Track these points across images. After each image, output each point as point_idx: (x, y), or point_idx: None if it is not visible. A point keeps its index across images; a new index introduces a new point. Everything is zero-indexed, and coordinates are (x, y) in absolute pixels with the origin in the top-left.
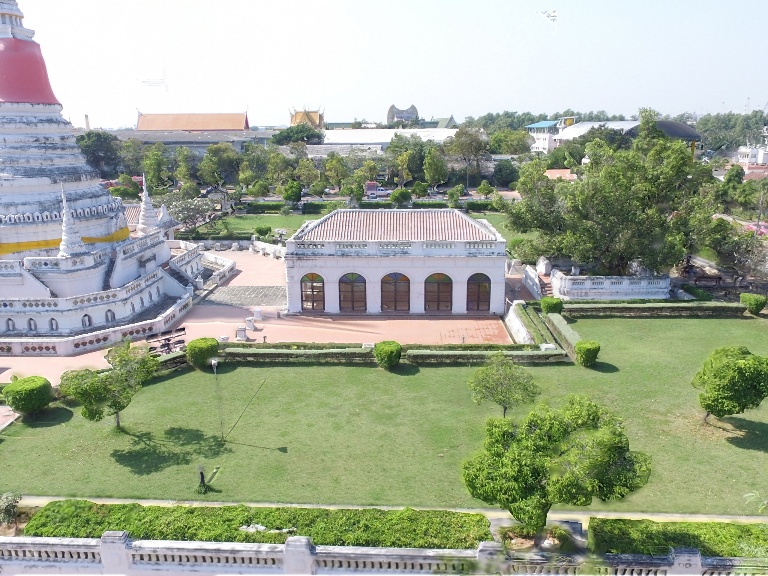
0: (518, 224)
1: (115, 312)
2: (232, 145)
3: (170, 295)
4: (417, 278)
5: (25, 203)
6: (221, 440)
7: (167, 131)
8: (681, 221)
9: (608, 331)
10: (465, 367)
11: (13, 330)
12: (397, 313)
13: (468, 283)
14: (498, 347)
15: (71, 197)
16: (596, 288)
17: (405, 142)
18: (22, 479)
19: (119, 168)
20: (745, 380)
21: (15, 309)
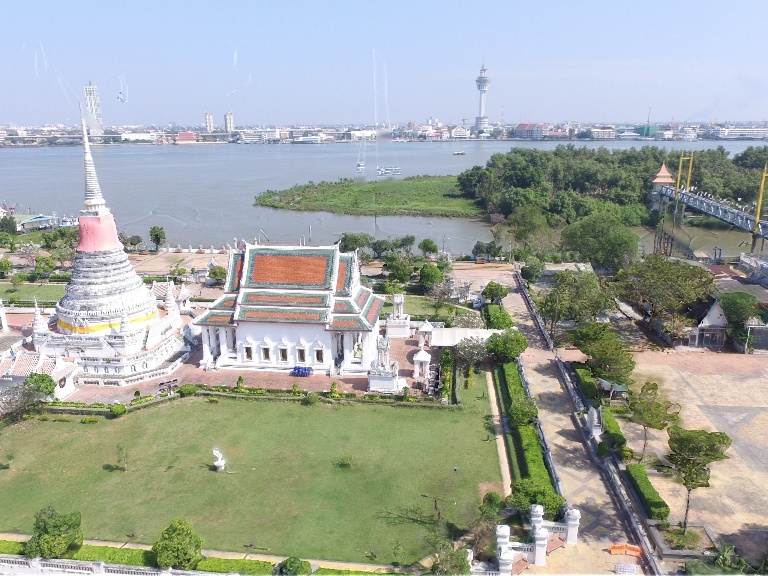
0: None
1: None
2: None
3: None
4: None
5: None
6: None
7: None
8: None
9: None
10: None
11: None
12: None
13: None
14: None
15: None
16: None
17: None
18: None
19: None
20: None
21: None
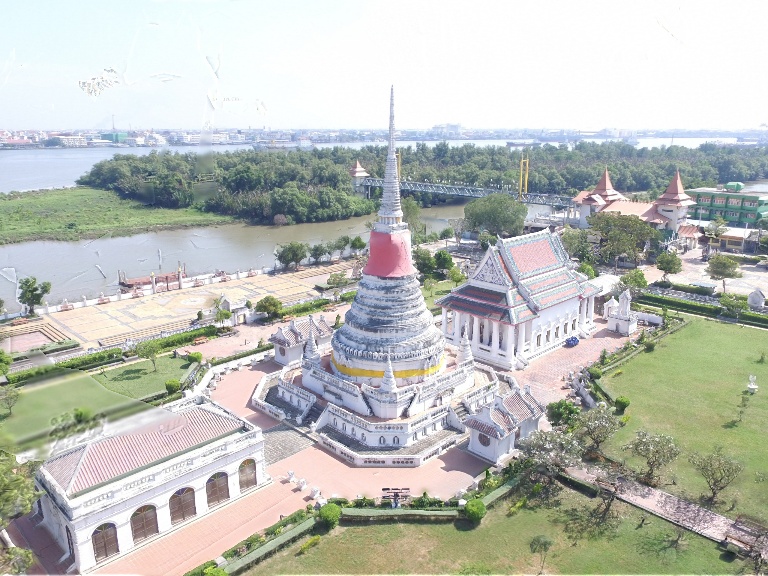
0: None
1: None
2: None
3: None
4: None
5: None
6: None
7: None
8: None
9: None
10: None
11: None
12: None
13: None
14: None
15: None
16: None
17: None
18: None
19: None
20: None
21: None
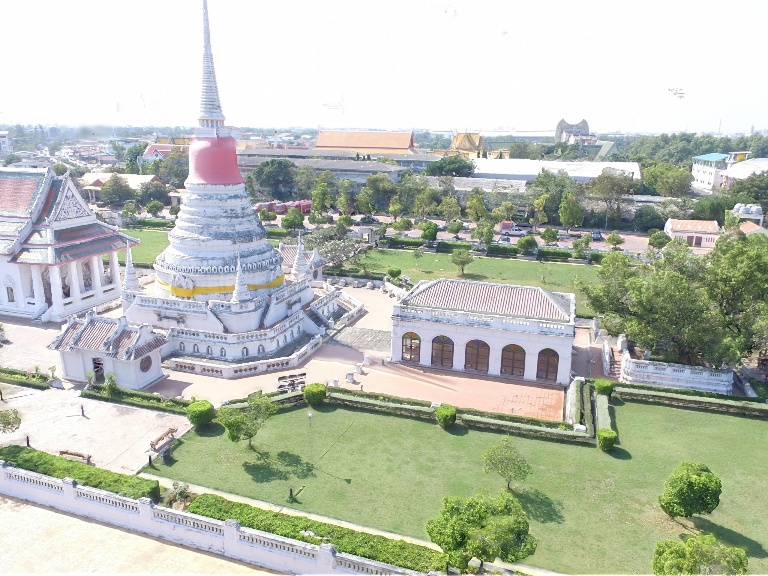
0: (596, 306)
1: (265, 347)
2: (389, 175)
3: (308, 332)
4: (496, 346)
5: (214, 258)
6: (311, 466)
7: (339, 151)
8: (748, 322)
9: (646, 418)
10: (505, 435)
11: (197, 352)
12: (477, 372)
13: (539, 355)
14: (538, 421)
15: (245, 254)
16: (658, 373)
17: (551, 178)
18: (191, 472)
19: (293, 191)
20: (695, 492)
21: (200, 338)
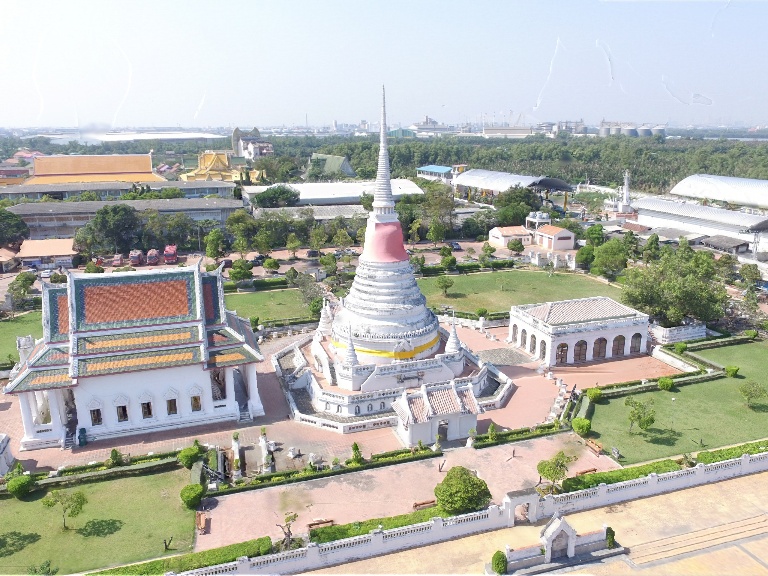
0: (634, 302)
1: None
2: None
3: None
4: (610, 339)
5: (419, 321)
6: (671, 430)
7: (105, 183)
8: (710, 295)
9: None
10: None
11: None
12: (600, 359)
13: (632, 339)
14: (692, 373)
15: (428, 313)
16: (679, 333)
17: None
18: None
19: (142, 237)
20: None
21: None
